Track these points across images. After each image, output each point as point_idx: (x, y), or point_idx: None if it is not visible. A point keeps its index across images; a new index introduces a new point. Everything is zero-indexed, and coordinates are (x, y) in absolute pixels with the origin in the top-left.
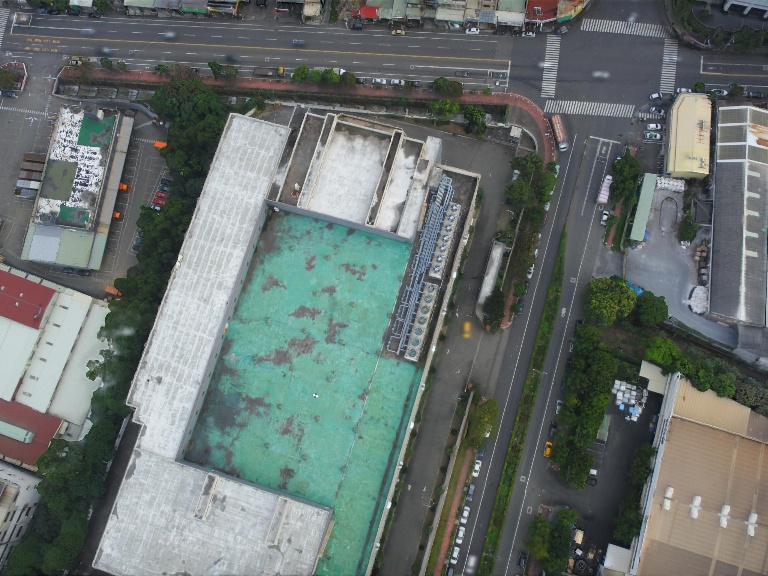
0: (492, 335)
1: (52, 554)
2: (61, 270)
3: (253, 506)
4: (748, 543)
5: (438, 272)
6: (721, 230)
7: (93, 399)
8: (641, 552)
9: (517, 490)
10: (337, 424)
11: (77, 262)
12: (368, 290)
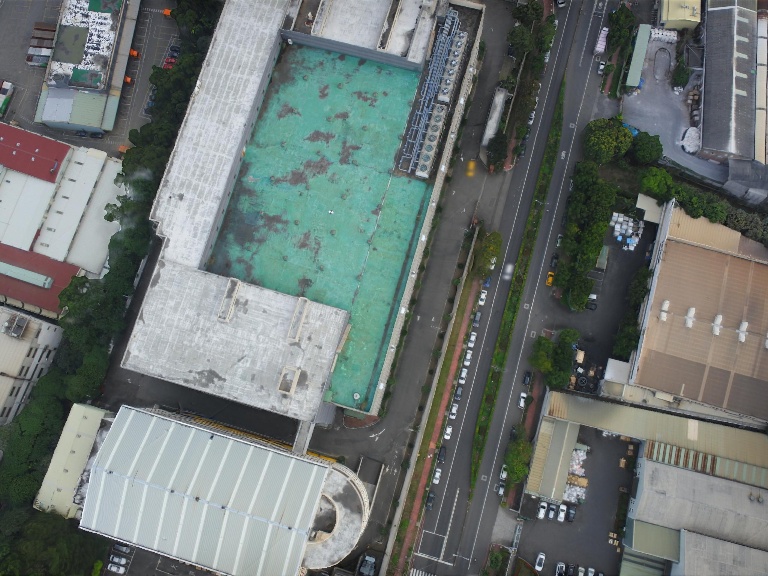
0: (496, 177)
1: (76, 380)
2: (74, 134)
3: (274, 308)
4: (739, 350)
5: (447, 94)
6: (712, 72)
7: (111, 243)
8: (639, 361)
9: (521, 316)
10: (352, 237)
11: (90, 122)
12: (380, 115)
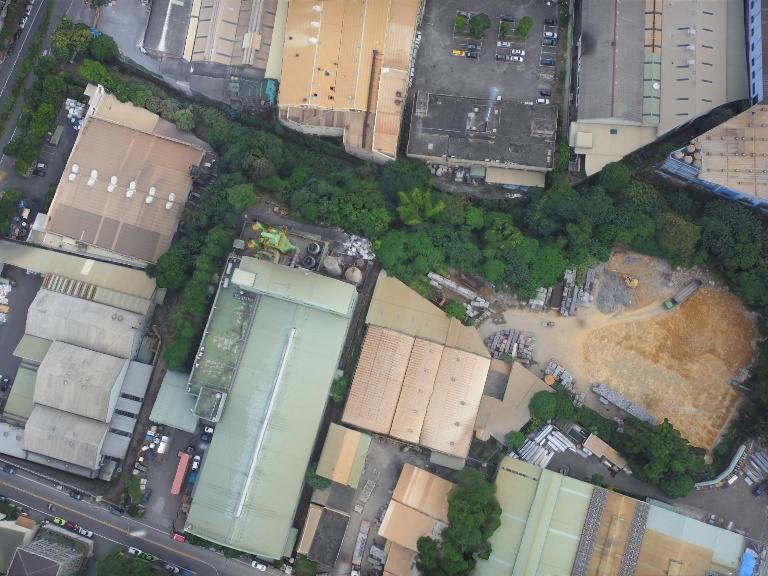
0: None
1: None
2: None
3: None
4: (128, 204)
5: None
6: None
7: None
8: (51, 213)
9: None
10: None
11: None
12: None
